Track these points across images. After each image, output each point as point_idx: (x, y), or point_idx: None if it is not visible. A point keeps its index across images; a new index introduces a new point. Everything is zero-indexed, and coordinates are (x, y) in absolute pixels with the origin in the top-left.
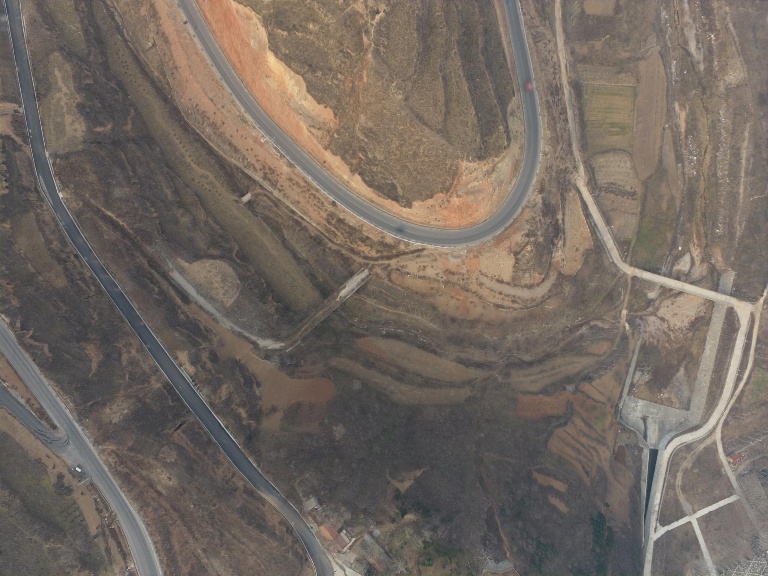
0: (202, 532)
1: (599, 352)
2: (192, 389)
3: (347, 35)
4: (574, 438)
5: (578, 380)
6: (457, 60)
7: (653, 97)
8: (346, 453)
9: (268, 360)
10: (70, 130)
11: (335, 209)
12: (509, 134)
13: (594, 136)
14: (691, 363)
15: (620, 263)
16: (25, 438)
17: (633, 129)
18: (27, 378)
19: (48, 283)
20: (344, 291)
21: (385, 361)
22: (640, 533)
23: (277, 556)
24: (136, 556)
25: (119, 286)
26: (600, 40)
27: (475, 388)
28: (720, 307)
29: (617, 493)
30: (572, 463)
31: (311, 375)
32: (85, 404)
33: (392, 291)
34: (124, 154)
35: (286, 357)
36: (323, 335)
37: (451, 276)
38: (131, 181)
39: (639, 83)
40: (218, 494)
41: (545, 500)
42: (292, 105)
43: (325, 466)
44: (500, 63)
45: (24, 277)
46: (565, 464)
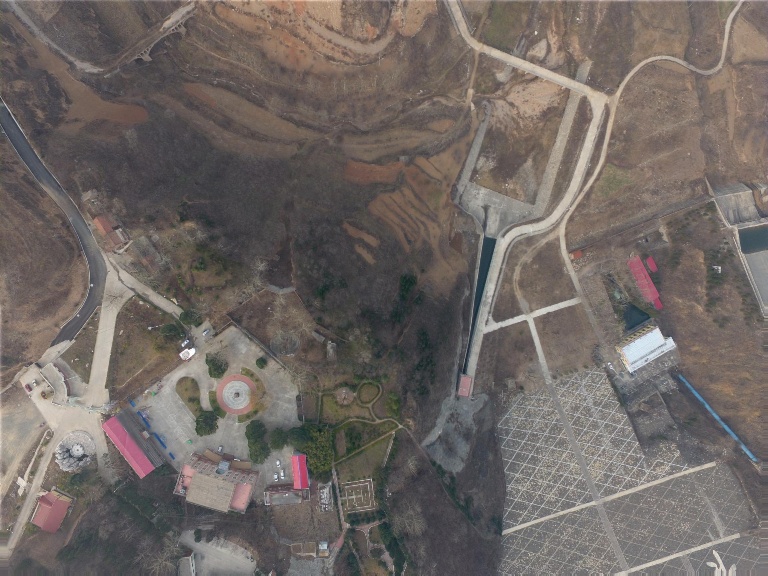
0: None
1: (440, 129)
2: None
3: None
4: (401, 207)
5: (414, 153)
6: None
7: None
8: (138, 162)
9: (84, 82)
10: None
11: None
12: None
13: None
14: (540, 155)
15: (468, 37)
16: None
17: None
18: None
19: None
20: (168, 22)
21: (211, 108)
22: (458, 307)
23: (43, 238)
24: None
25: None
26: None
27: (303, 147)
28: (574, 98)
29: (442, 270)
30: (392, 227)
31: None
32: None
33: (220, 31)
34: None
35: (104, 84)
36: (150, 74)
37: (278, 16)
38: None
39: None
40: None
41: (350, 247)
42: None
43: (111, 167)
44: None
45: None
46: (383, 225)
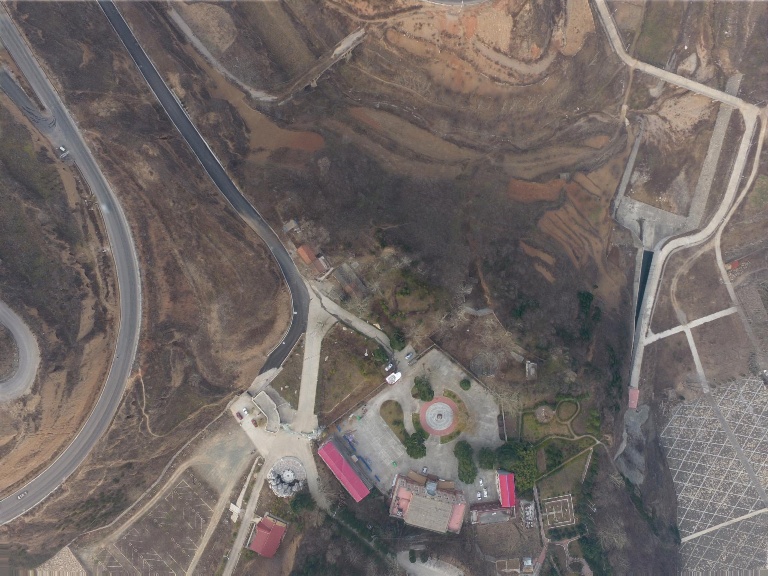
0: (180, 232)
1: (596, 146)
2: (181, 110)
3: None
4: (566, 224)
5: (573, 170)
6: None
7: None
8: (330, 190)
9: (259, 111)
10: None
11: None
12: None
13: None
14: (692, 167)
15: (622, 54)
16: (13, 108)
17: None
18: (19, 59)
19: None
20: (339, 49)
21: (377, 131)
22: (629, 321)
23: (253, 268)
24: (113, 240)
25: (117, 8)
26: None
27: (467, 168)
28: (725, 110)
29: (608, 285)
30: (562, 244)
31: (301, 130)
32: (74, 90)
33: (387, 56)
34: None
35: (278, 112)
36: (316, 100)
37: (447, 40)
38: None
39: None
40: (198, 197)
41: None
42: None
43: (308, 195)
44: None
45: None
46: (554, 242)
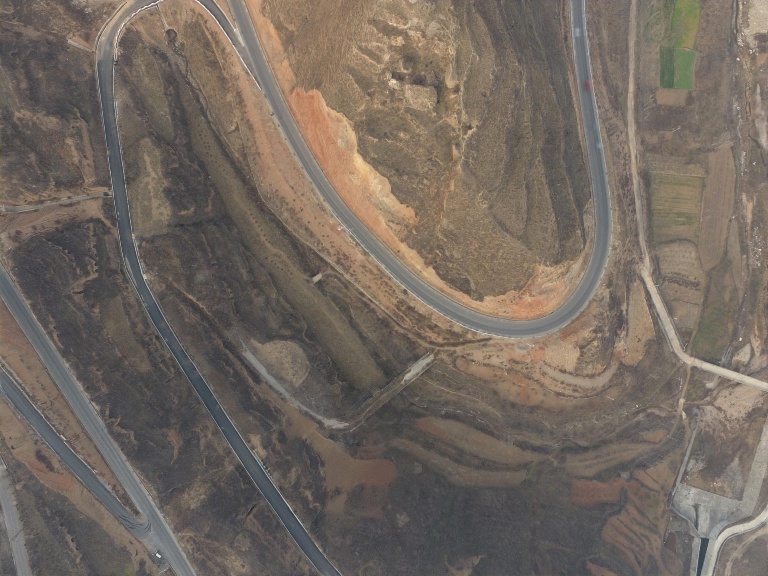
0: None
1: (655, 440)
2: (263, 472)
3: (437, 145)
4: (627, 526)
5: (633, 467)
6: (540, 168)
7: (721, 189)
8: (408, 540)
9: (332, 439)
10: (156, 214)
11: (406, 297)
12: (584, 236)
13: (660, 225)
14: (746, 453)
15: (680, 353)
16: (111, 525)
17: (699, 219)
18: (113, 464)
19: (133, 367)
20: (409, 375)
21: (444, 442)
22: None
23: None
24: None
25: (197, 368)
26: (671, 130)
27: (531, 471)
28: None
29: None
30: (625, 553)
31: (373, 455)
32: (166, 491)
33: (455, 375)
34: (204, 236)
35: (349, 436)
36: (384, 414)
37: (515, 365)
38: (210, 263)
39: (708, 175)
40: None
41: None
42: (373, 200)
43: (388, 554)
44: (579, 165)
45: (112, 362)
46: (618, 554)
